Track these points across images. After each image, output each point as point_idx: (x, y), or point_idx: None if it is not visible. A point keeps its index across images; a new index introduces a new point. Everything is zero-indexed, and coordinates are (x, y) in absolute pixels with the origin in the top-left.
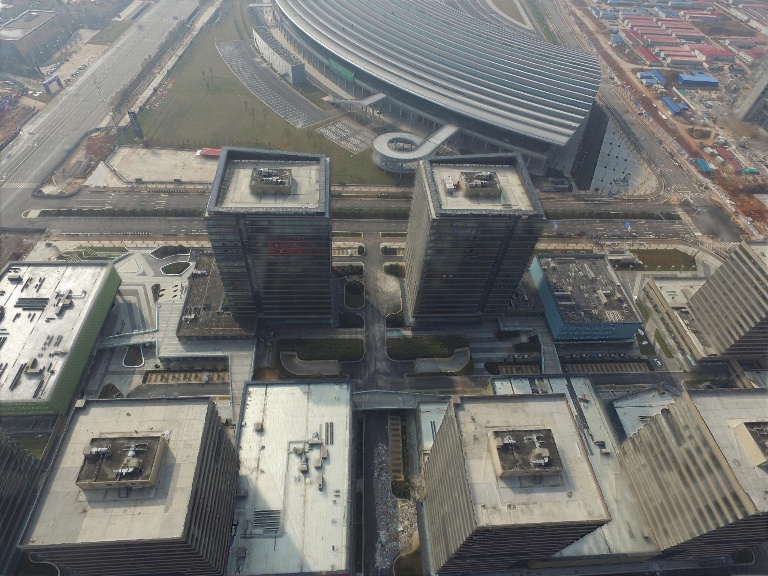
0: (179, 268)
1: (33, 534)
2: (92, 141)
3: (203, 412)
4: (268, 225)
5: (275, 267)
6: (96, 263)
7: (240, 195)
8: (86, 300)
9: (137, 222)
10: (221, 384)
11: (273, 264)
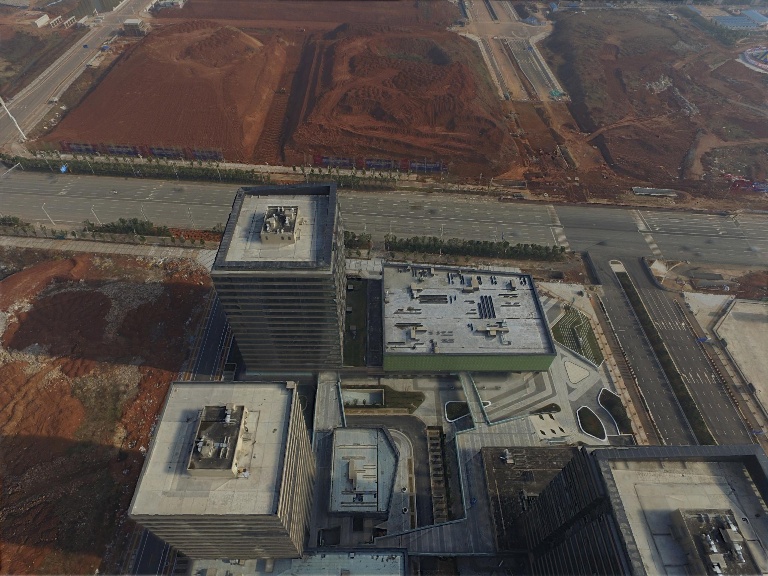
0: (592, 427)
1: (182, 388)
2: (765, 276)
3: (263, 509)
4: (611, 557)
5: (575, 575)
6: (550, 341)
7: (657, 495)
8: (500, 348)
9: (649, 361)
10: (431, 515)
11: (577, 572)
